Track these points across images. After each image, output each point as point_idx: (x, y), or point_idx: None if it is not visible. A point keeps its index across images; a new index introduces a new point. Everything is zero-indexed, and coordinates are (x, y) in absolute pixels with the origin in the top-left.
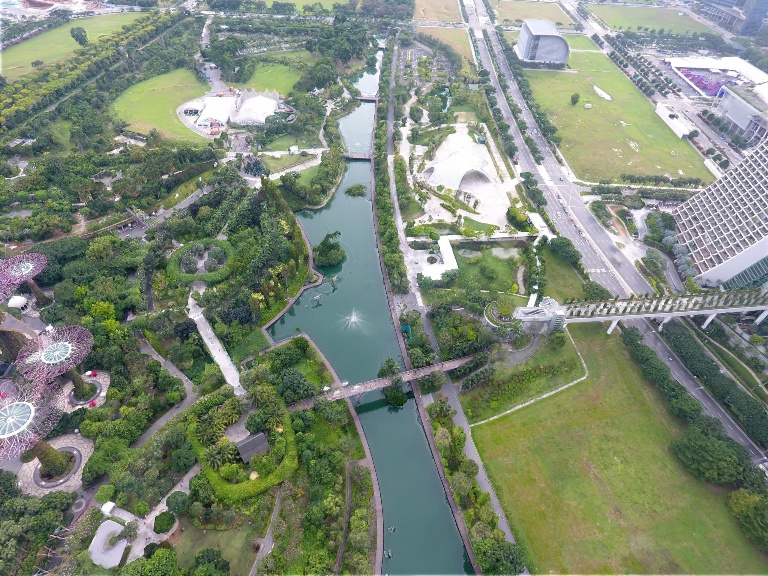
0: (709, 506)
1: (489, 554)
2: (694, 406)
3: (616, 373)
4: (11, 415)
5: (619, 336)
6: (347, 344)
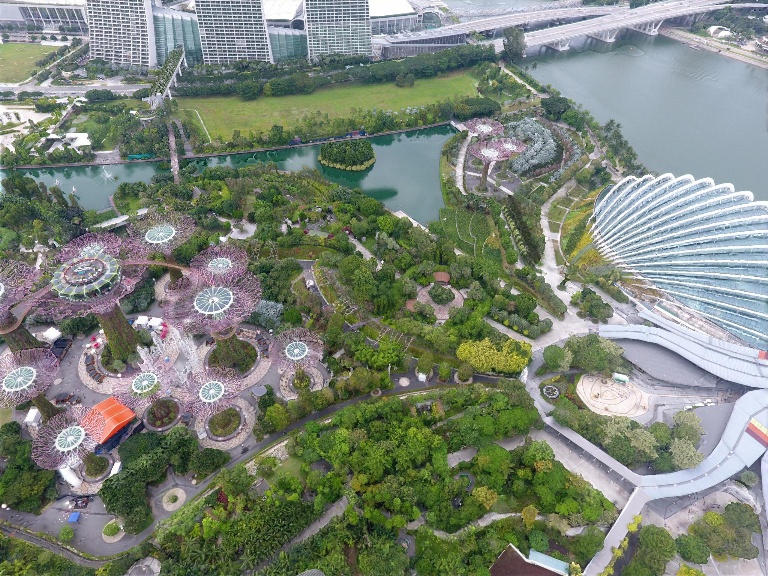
0: (266, 100)
1: (275, 132)
2: (226, 84)
3: (198, 104)
4: None
5: (175, 98)
6: (129, 182)
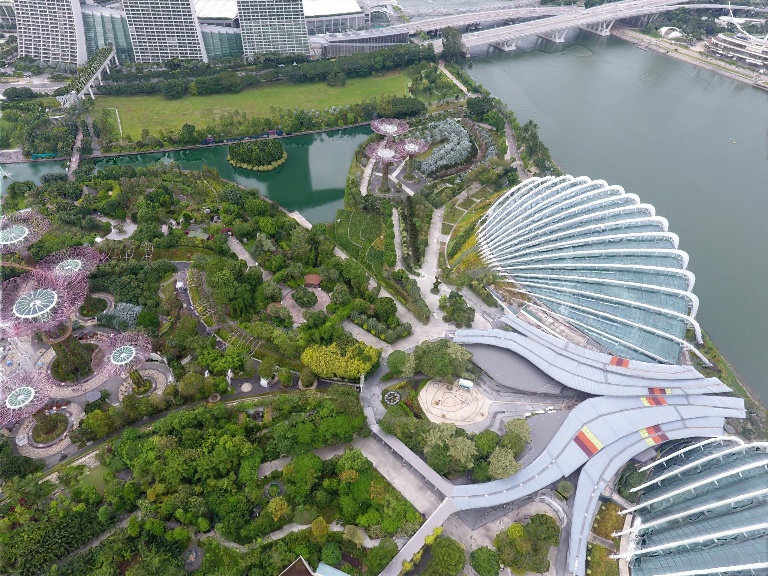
0: (191, 99)
1: (184, 131)
2: (150, 83)
3: (120, 102)
4: (7, 235)
5: (98, 97)
6: None
